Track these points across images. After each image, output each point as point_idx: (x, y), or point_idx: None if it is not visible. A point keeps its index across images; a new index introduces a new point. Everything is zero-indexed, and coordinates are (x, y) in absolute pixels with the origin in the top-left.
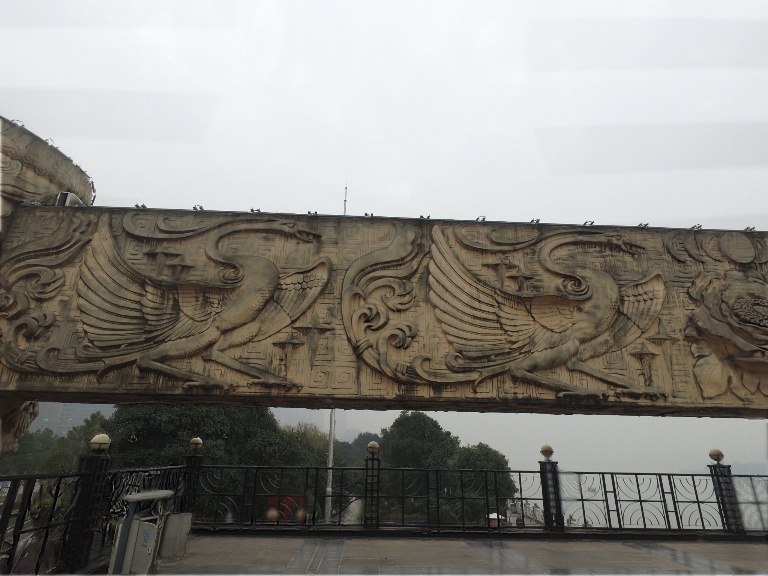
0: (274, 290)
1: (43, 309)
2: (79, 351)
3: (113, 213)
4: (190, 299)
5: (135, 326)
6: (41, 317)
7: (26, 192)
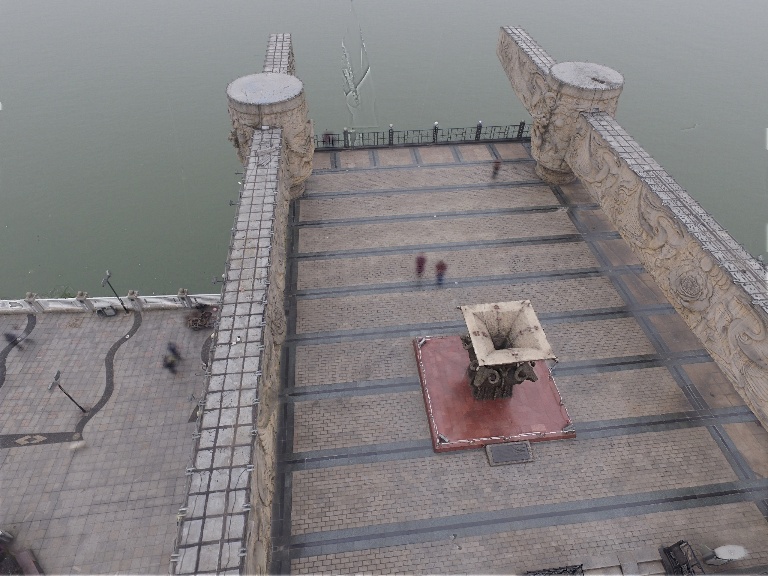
0: None
1: None
2: None
3: None
4: None
5: None
6: None
7: None
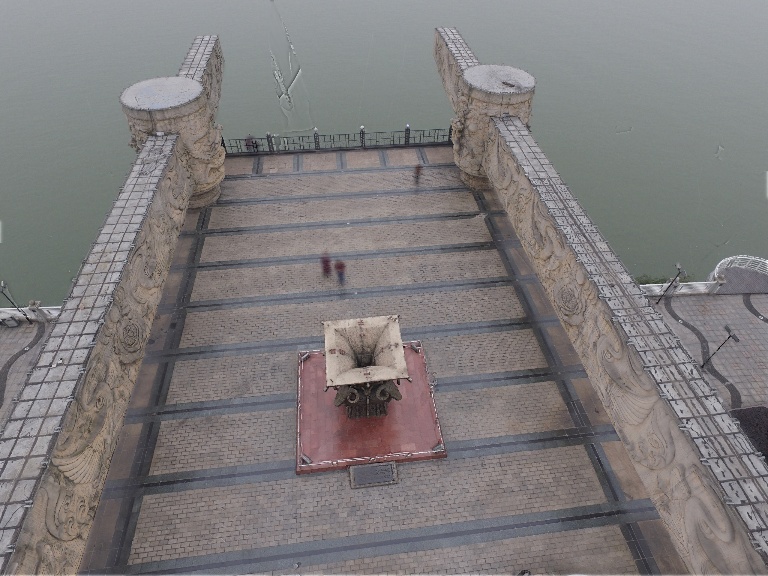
0: None
1: None
2: None
3: None
4: None
5: None
6: None
7: None
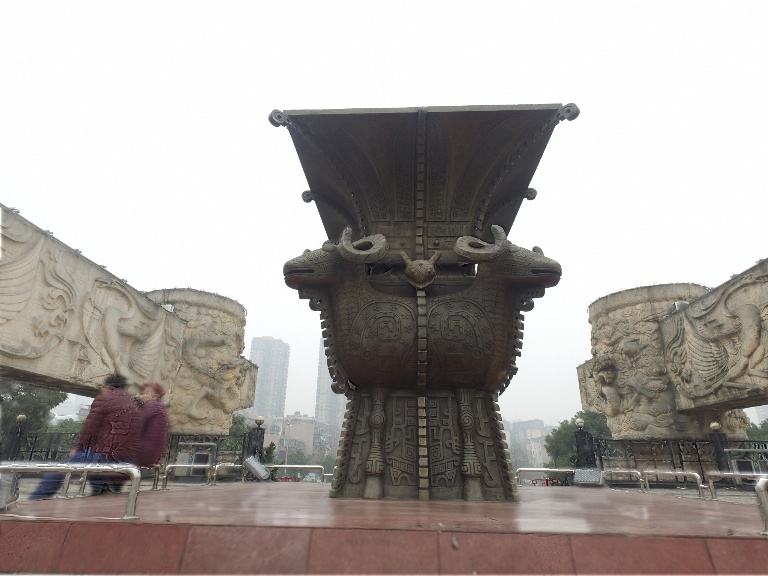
0: (759, 323)
1: (686, 367)
2: (703, 384)
3: (685, 309)
4: (727, 343)
5: (716, 365)
6: (686, 372)
7: (658, 314)
